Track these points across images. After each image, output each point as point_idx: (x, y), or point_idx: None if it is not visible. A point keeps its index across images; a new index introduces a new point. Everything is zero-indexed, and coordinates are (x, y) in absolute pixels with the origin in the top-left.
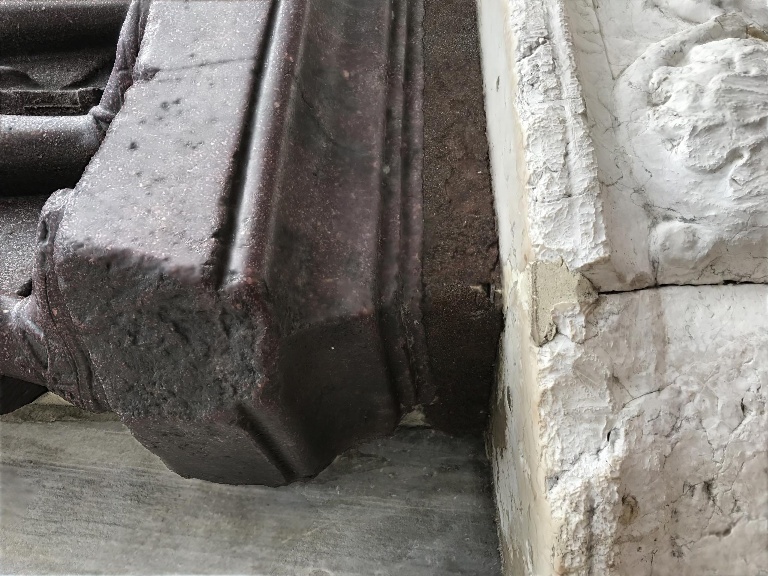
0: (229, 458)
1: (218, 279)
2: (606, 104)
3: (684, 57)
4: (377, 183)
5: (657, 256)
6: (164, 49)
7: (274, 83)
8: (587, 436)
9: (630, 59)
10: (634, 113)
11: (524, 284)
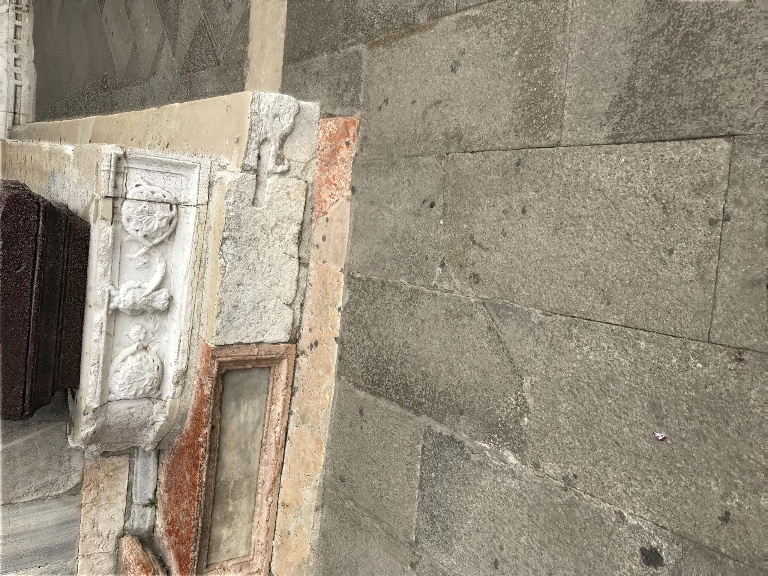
0: None
1: None
2: None
3: None
4: None
5: None
6: None
7: None
8: None
9: None
10: None
11: None
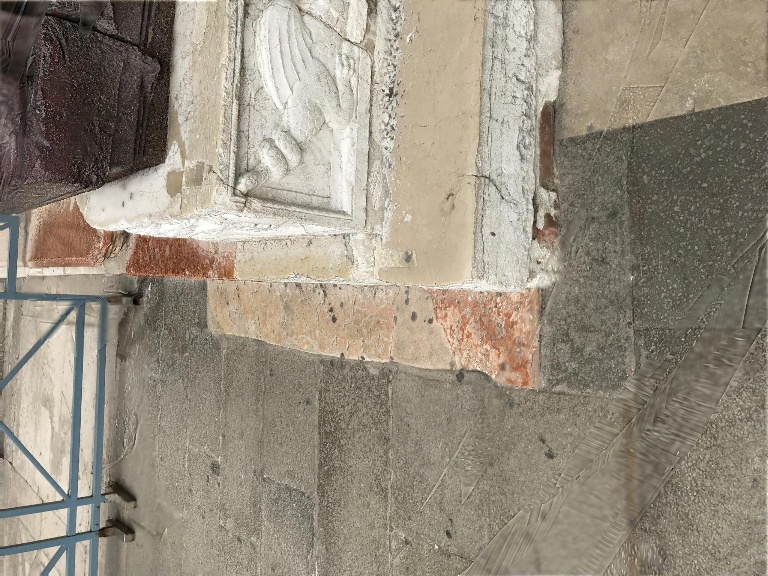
0: None
1: None
2: None
3: None
4: None
5: None
6: None
7: None
8: None
9: None
10: None
11: None
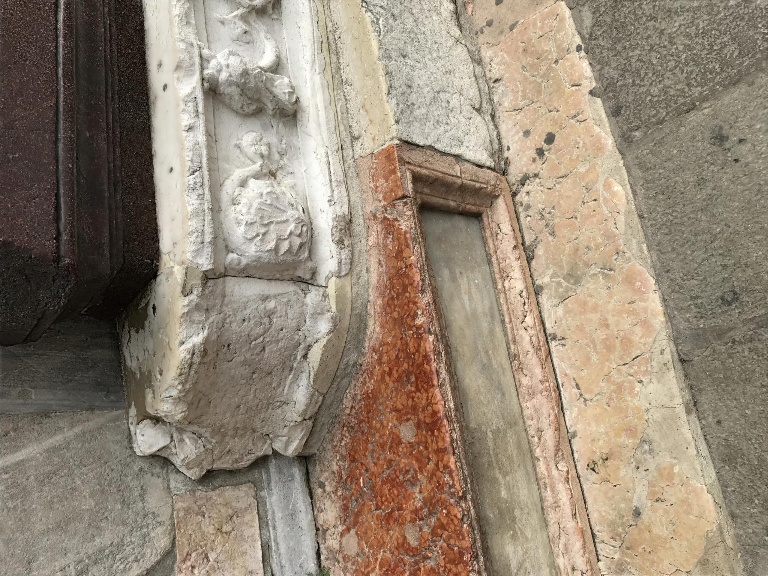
0: (2, 332)
1: (58, 260)
2: (217, 199)
3: (247, 182)
4: (107, 205)
5: (227, 266)
6: None
7: (66, 151)
8: (195, 329)
9: (227, 175)
10: (227, 207)
11: (180, 271)
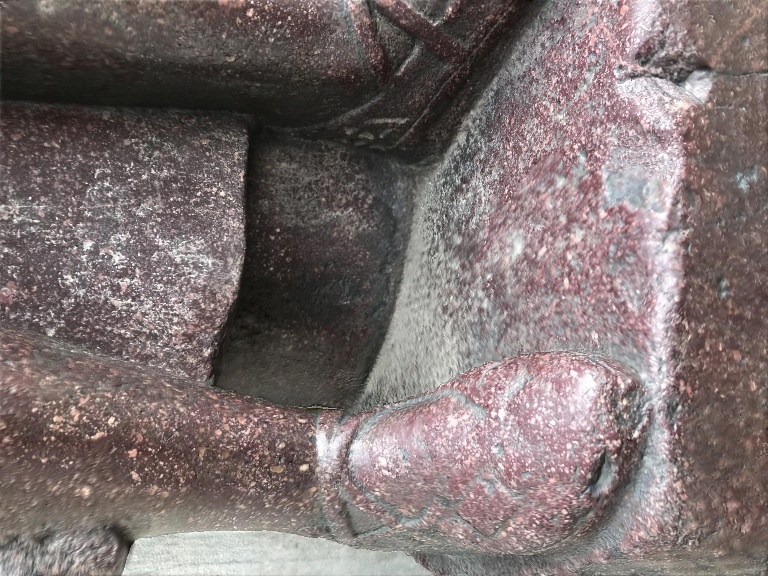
0: None
1: None
2: None
3: None
4: None
5: None
6: (707, 6)
7: None
8: None
9: None
10: None
11: None
